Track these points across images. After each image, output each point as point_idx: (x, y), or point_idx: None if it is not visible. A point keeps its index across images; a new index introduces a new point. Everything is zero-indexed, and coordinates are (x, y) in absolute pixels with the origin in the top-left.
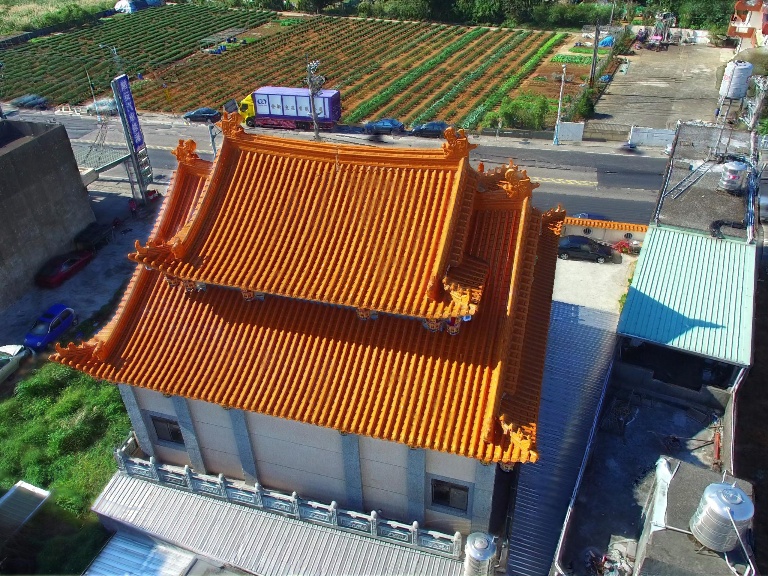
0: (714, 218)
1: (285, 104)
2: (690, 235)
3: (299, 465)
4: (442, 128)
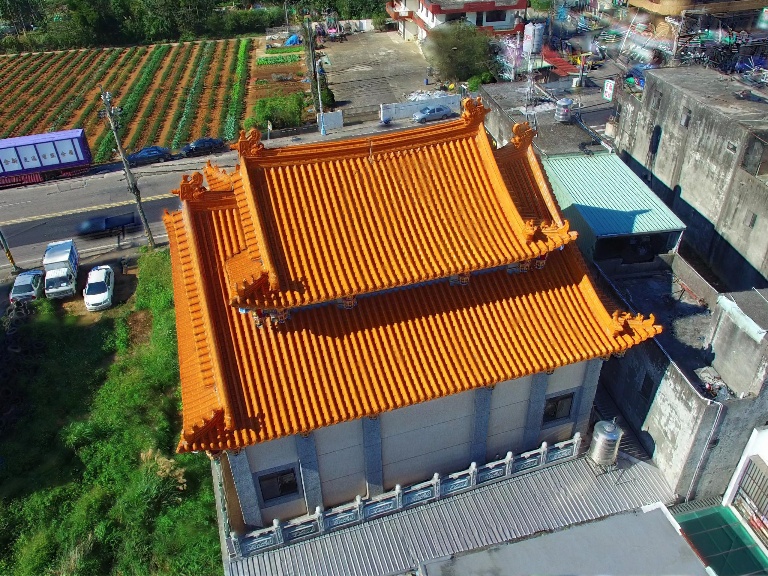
0: (575, 143)
1: (22, 156)
2: (572, 158)
3: (426, 449)
4: (213, 143)
